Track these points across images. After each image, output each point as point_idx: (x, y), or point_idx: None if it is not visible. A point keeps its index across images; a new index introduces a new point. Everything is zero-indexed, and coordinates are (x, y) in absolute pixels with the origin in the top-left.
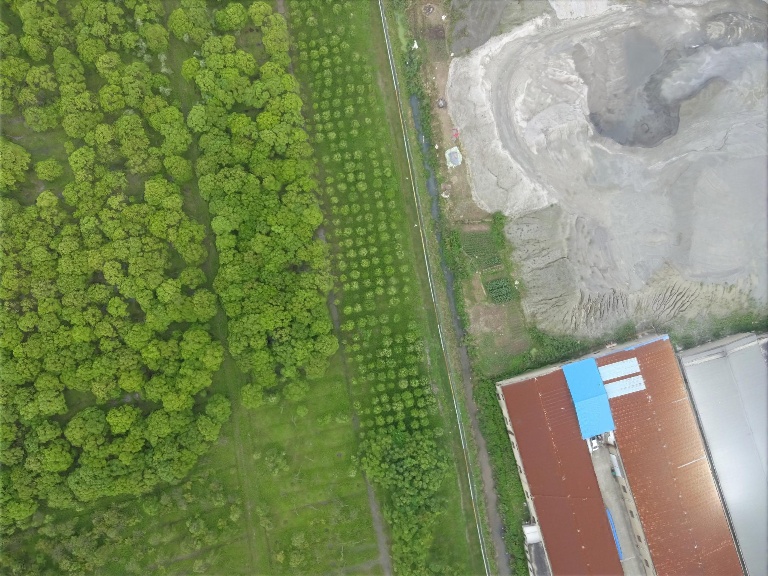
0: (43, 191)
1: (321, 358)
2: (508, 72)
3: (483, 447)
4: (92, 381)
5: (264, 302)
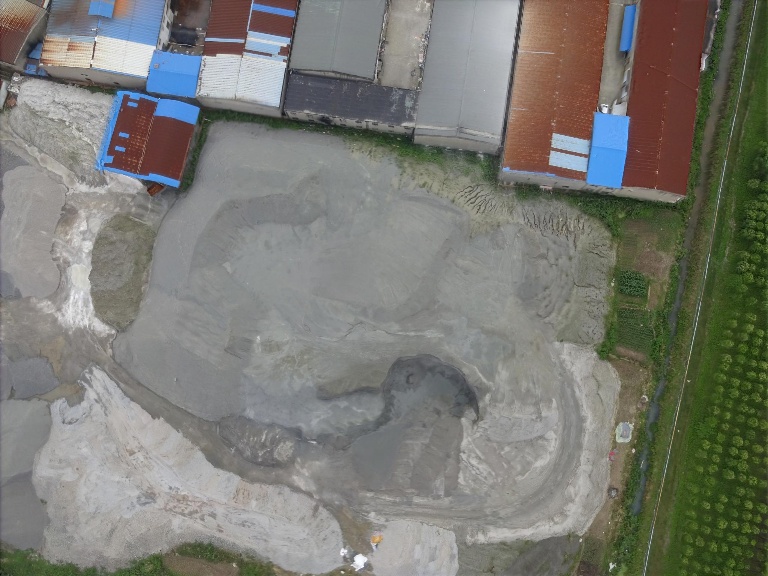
0: None
1: None
2: (539, 497)
3: (703, 154)
4: None
5: None
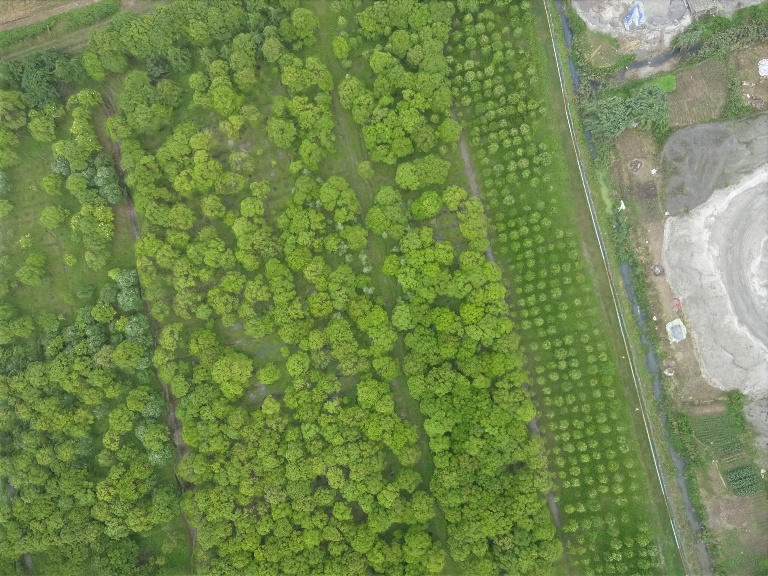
0: (266, 395)
1: (547, 566)
2: (738, 231)
3: None
4: None
5: (484, 510)
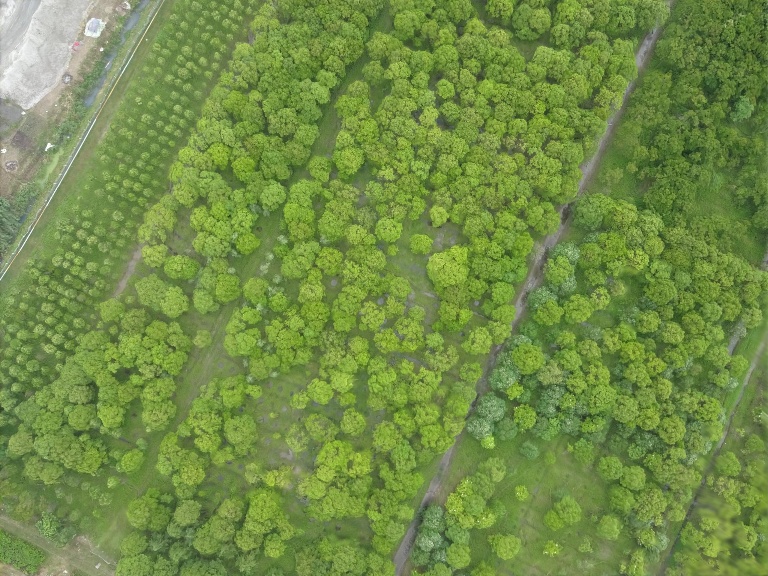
0: (438, 230)
1: None
2: None
3: None
4: (503, 47)
5: (332, 4)
